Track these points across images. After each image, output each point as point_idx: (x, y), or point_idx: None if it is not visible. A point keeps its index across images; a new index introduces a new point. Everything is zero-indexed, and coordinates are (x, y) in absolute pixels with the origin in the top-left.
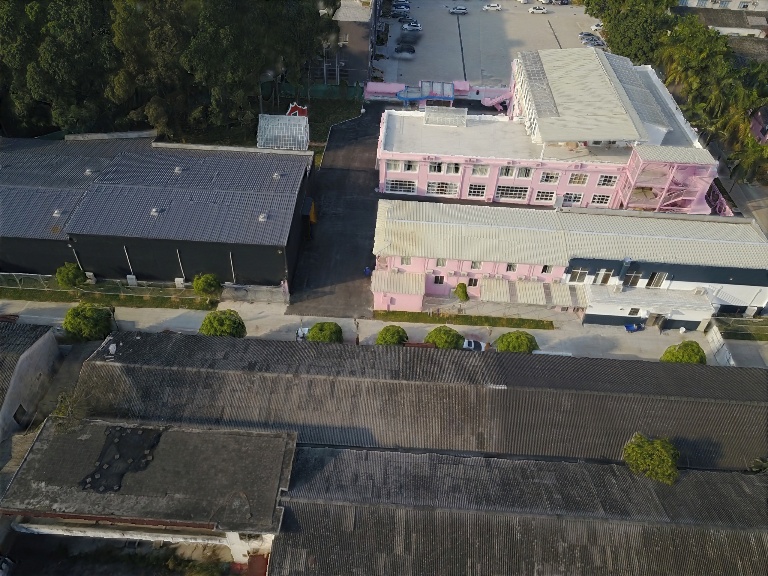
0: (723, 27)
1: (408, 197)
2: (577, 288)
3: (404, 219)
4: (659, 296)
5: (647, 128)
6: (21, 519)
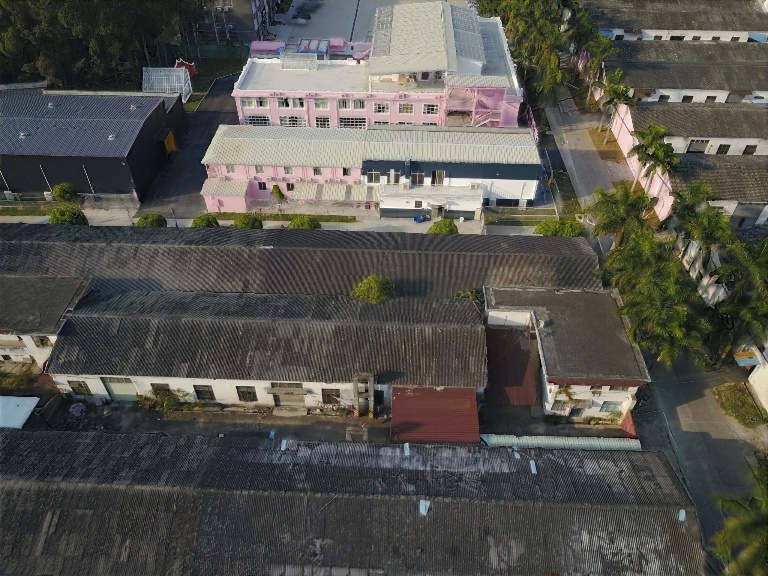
0: None
1: None
2: (374, 188)
3: (233, 137)
4: (440, 191)
5: (464, 63)
6: None
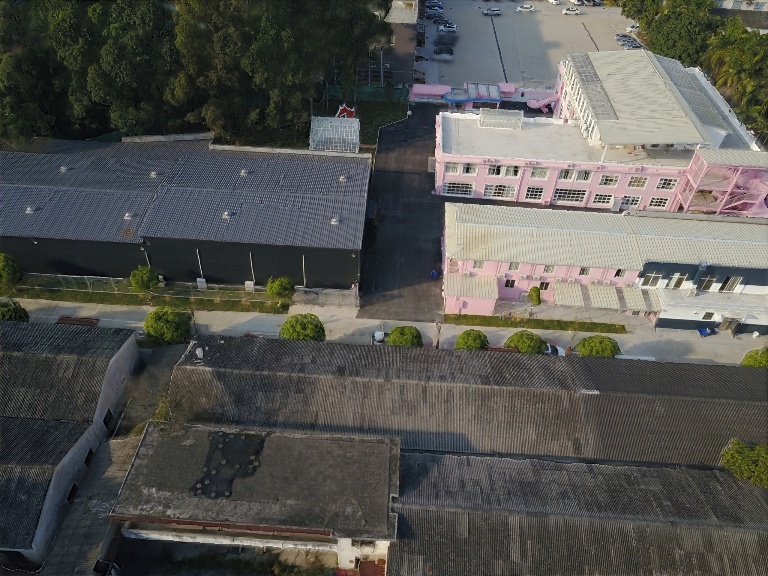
0: (761, 29)
1: (465, 200)
2: (650, 292)
3: (474, 222)
4: (733, 300)
5: (707, 131)
6: (129, 525)
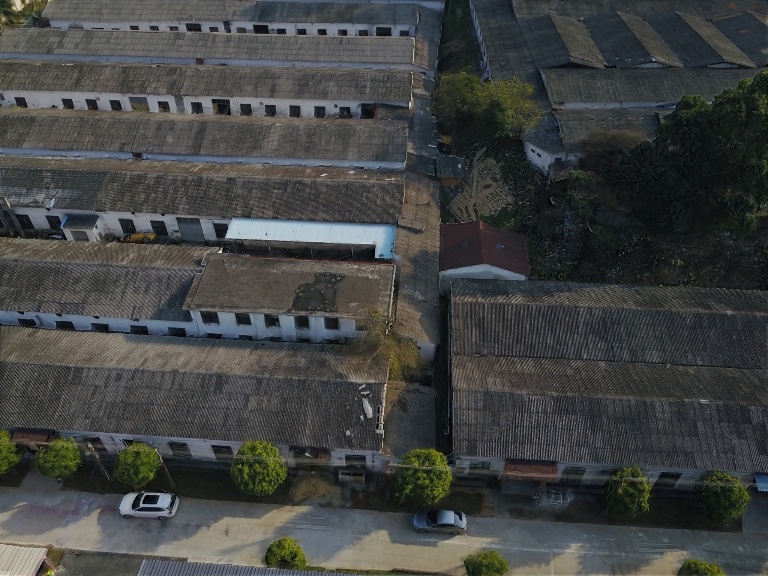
0: None
1: None
2: None
3: None
4: None
5: None
6: None
